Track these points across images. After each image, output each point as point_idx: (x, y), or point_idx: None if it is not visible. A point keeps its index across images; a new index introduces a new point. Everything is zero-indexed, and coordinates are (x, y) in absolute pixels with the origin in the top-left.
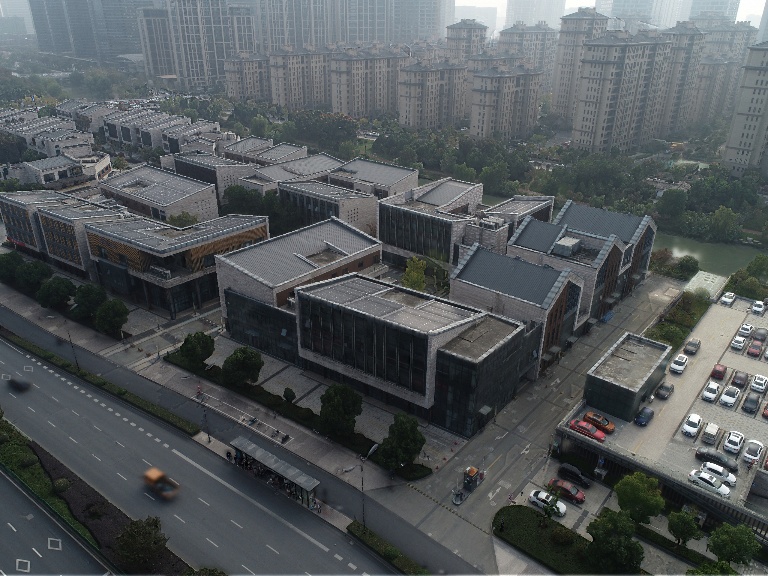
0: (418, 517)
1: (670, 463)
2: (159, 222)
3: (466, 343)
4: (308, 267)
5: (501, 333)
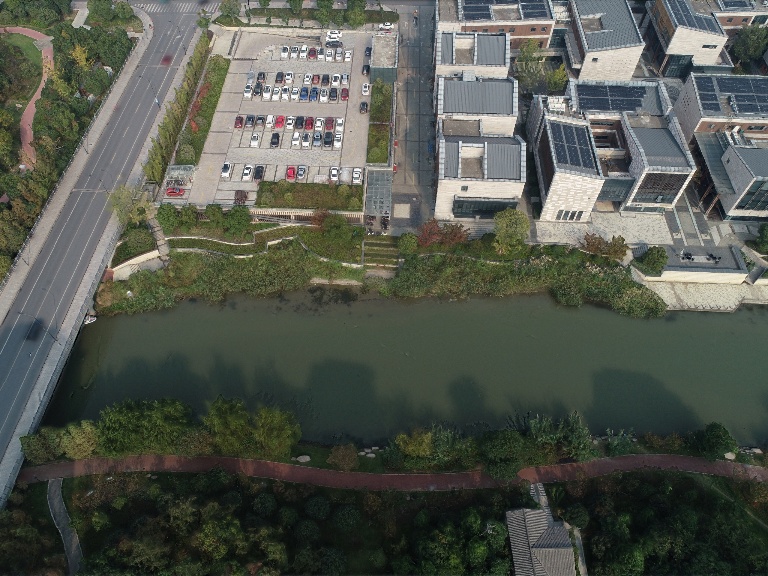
0: (422, 8)
1: (351, 39)
2: (739, 11)
3: (451, 4)
4: (584, 13)
5: (443, 15)
